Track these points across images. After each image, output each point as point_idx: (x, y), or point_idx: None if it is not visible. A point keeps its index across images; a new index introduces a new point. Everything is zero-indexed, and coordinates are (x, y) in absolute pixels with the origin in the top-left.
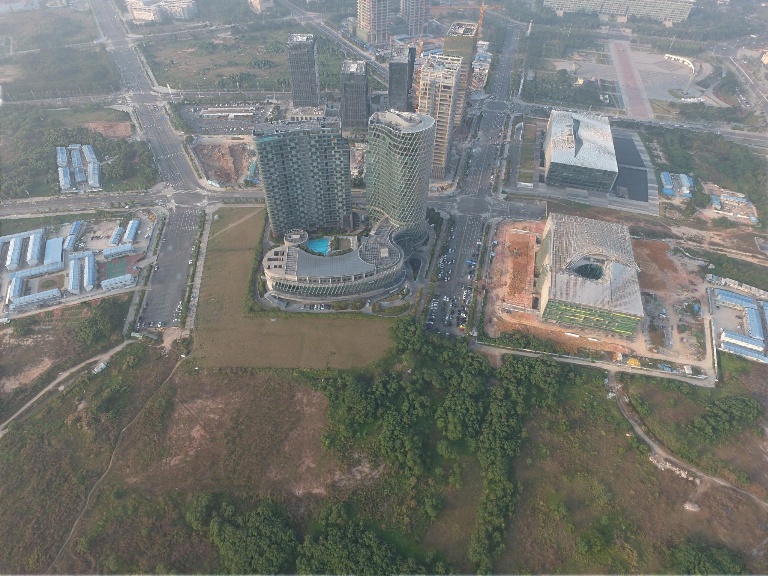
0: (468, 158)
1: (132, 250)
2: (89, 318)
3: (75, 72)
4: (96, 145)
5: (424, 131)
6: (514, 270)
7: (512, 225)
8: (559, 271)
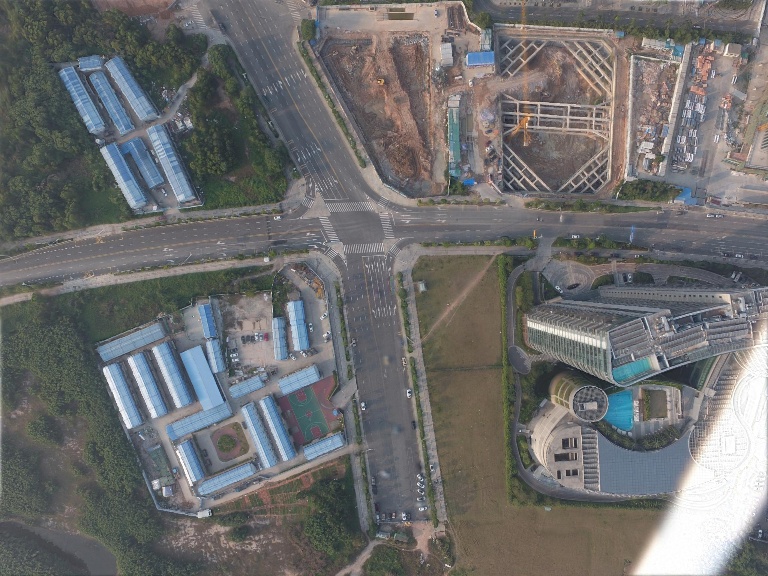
0: None
1: (319, 378)
2: (316, 518)
3: None
4: (129, 56)
5: None
6: None
7: None
8: None
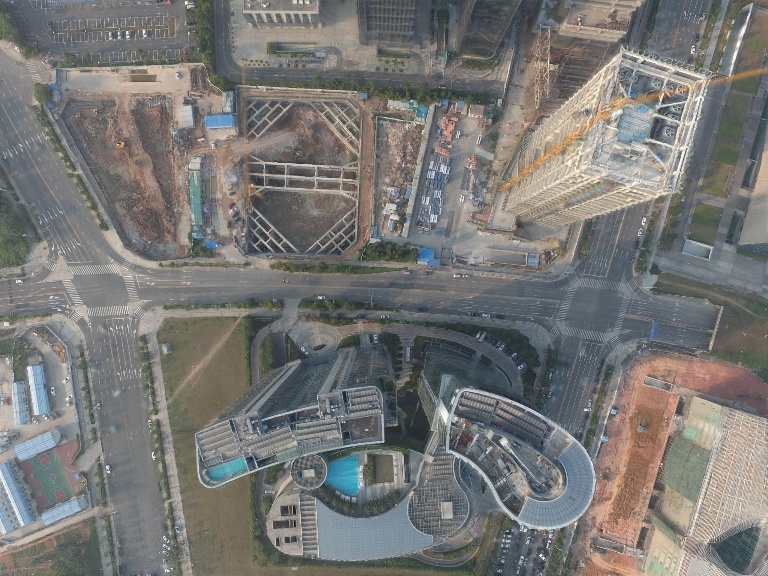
0: None
1: (58, 443)
2: None
3: None
4: None
5: None
6: (628, 471)
7: (648, 365)
8: (698, 552)
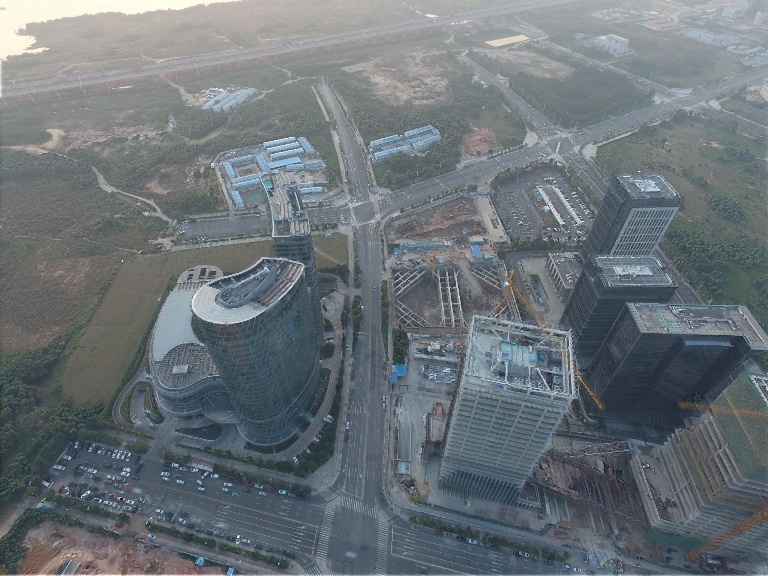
0: (532, 548)
1: None
2: (196, 196)
3: (583, 97)
4: None
5: (192, 310)
6: None
7: None
8: None
